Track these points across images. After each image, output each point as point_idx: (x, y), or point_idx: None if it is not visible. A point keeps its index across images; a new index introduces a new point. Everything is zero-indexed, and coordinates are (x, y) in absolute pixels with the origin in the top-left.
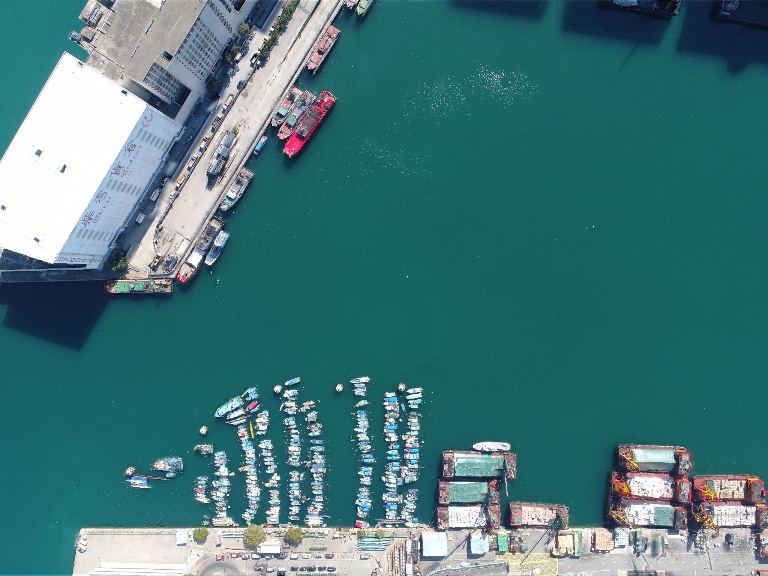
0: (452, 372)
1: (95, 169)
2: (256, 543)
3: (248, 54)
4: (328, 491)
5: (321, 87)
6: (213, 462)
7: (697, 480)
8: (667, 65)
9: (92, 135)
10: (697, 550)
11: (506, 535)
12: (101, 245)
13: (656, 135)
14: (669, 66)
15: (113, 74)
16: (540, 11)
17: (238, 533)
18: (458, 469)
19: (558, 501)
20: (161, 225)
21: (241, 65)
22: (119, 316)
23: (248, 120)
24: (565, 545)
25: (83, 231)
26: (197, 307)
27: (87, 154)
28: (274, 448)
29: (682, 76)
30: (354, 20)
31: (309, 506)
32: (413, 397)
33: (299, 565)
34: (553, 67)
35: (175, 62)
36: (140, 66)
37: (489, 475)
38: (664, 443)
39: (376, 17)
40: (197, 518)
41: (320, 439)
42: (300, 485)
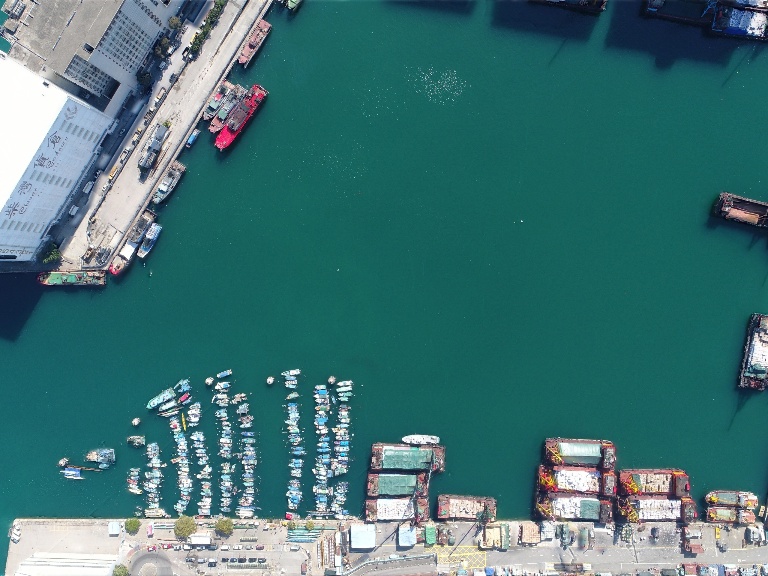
0: (382, 365)
1: (17, 160)
2: (186, 534)
3: (180, 48)
4: (259, 483)
5: (253, 81)
6: (146, 453)
7: (623, 474)
8: (595, 61)
9: (14, 127)
10: (623, 543)
11: (434, 527)
12: (32, 237)
13: (584, 130)
14: (597, 62)
15: (35, 66)
16: (470, 6)
17: (170, 524)
18: (386, 461)
19: (487, 494)
20: (94, 217)
21: (173, 59)
22: (53, 308)
23: (180, 113)
24: (492, 538)
25: (8, 222)
26: (130, 299)
27: (9, 145)
28: (206, 440)
29: (610, 72)
30: (286, 14)
31: (240, 498)
32: (343, 390)
33: (230, 556)
34: (482, 62)
35: (97, 54)
36: (62, 58)
37: (416, 468)
38: (591, 437)
39: (308, 11)
40: (130, 509)
41: (251, 431)
42: (231, 477)
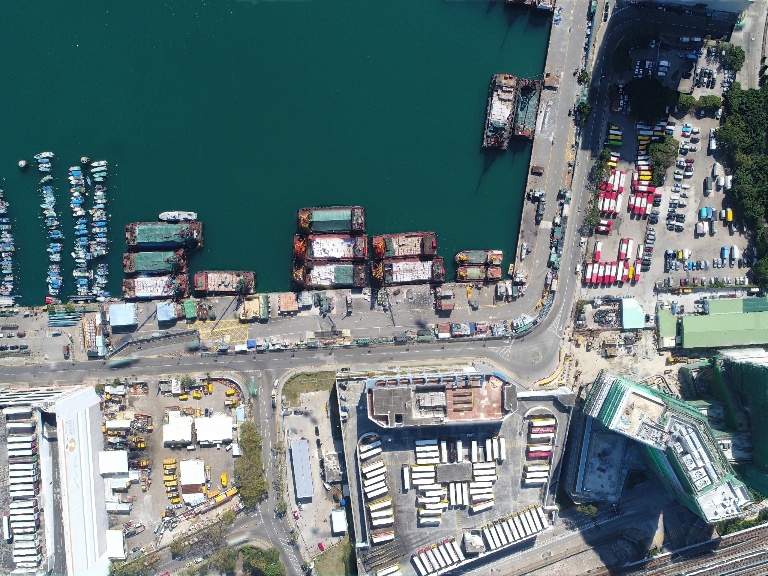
0: (135, 143)
1: None
2: None
3: None
4: (18, 270)
5: None
6: None
7: (376, 238)
8: None
9: None
10: (380, 308)
11: (192, 301)
12: None
13: None
14: None
15: None
16: None
17: None
18: (139, 236)
19: (247, 269)
20: None
21: None
22: None
23: None
24: (252, 309)
25: None
26: None
27: None
28: None
29: None
30: None
31: None
32: (97, 169)
33: None
34: None
35: None
36: None
37: (170, 240)
38: (343, 204)
39: None
40: None
41: (7, 217)
42: None
